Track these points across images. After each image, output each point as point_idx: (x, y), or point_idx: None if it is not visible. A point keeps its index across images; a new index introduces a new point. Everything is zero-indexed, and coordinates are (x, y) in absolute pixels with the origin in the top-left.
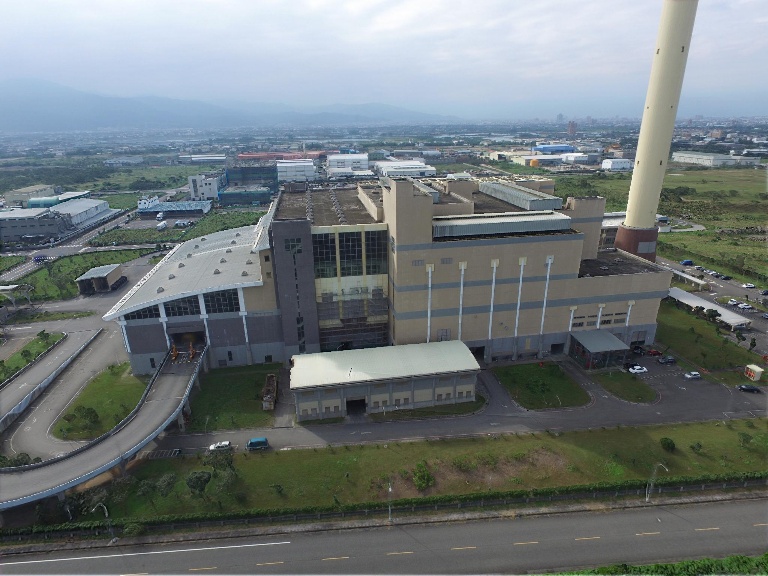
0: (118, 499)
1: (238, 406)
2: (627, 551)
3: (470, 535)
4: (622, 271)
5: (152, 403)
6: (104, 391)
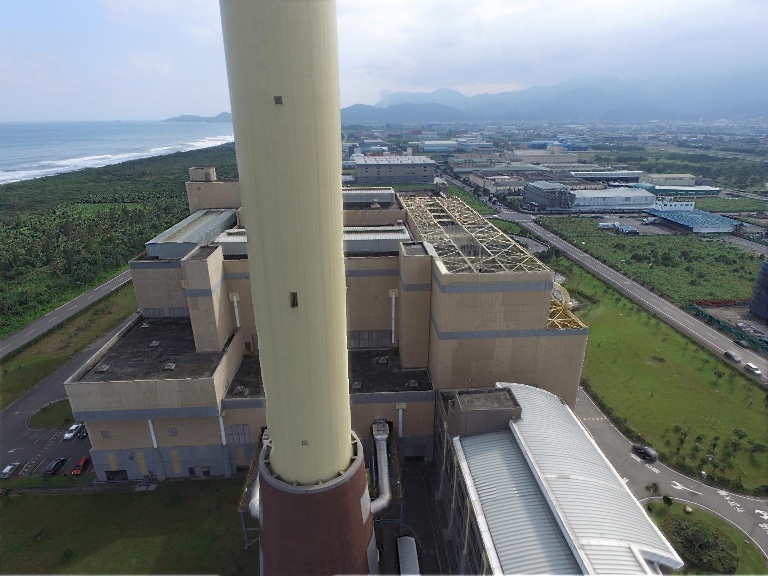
0: None
1: None
2: None
3: (56, 321)
4: (132, 355)
5: None
6: None
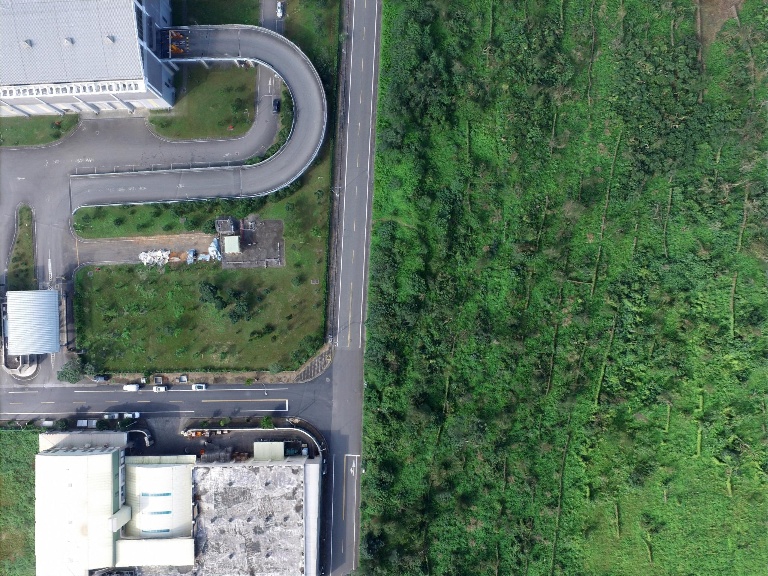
0: (325, 48)
1: (234, 8)
2: None
3: None
4: None
5: (242, 50)
6: (196, 119)
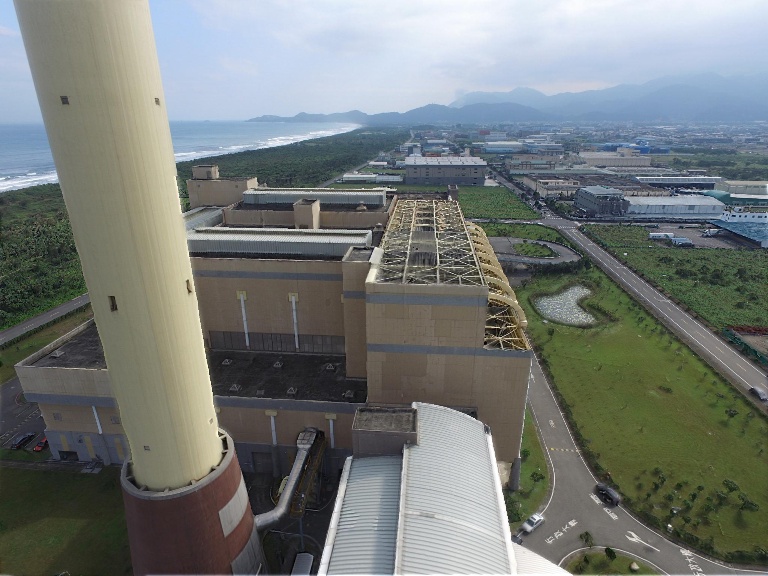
0: None
1: None
2: (7, 332)
3: (79, 305)
4: (90, 343)
5: None
6: None
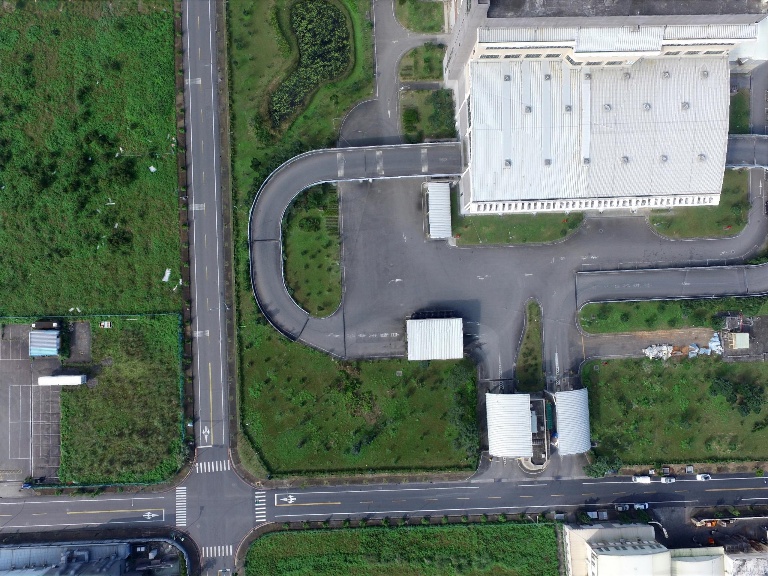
0: None
1: None
2: None
3: None
4: None
5: (758, 158)
6: (695, 219)
